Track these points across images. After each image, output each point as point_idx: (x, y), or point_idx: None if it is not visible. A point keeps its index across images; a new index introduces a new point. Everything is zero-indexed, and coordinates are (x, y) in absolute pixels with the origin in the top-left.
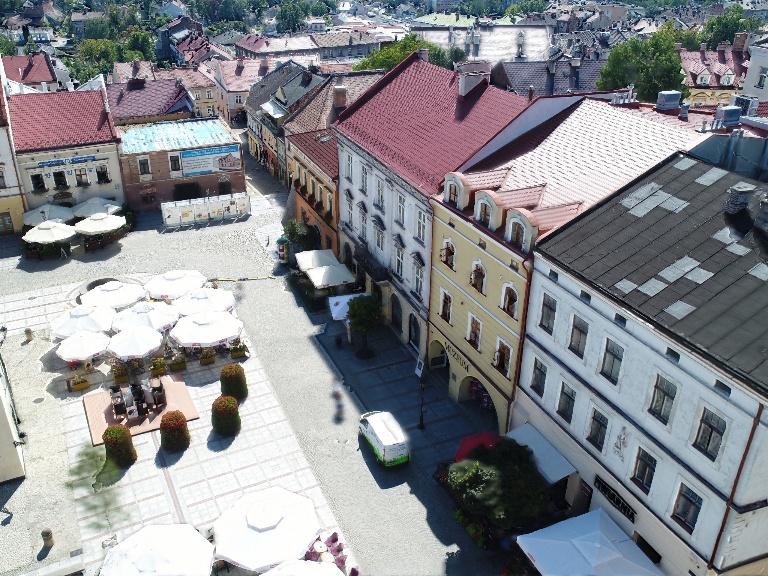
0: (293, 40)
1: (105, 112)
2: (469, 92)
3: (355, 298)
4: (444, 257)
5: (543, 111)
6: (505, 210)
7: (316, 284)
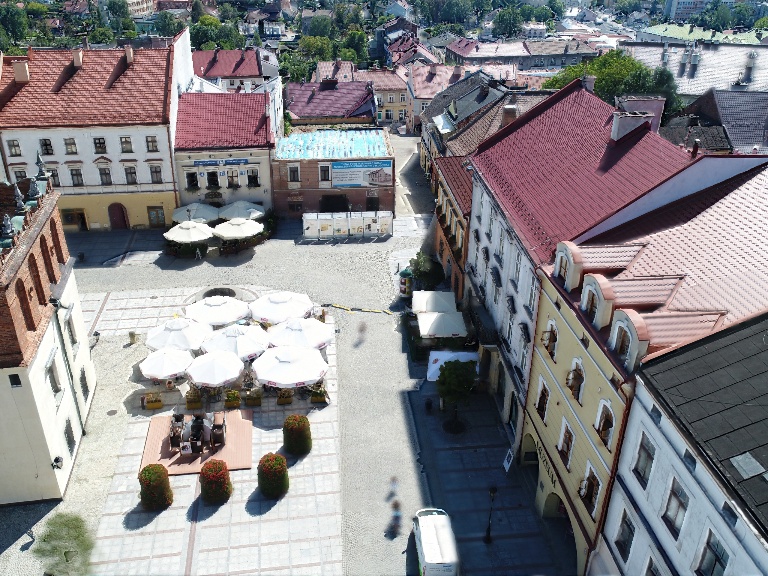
0: (504, 46)
1: (265, 116)
2: (623, 136)
3: (449, 362)
4: (547, 341)
5: (708, 174)
6: (616, 306)
7: (421, 332)
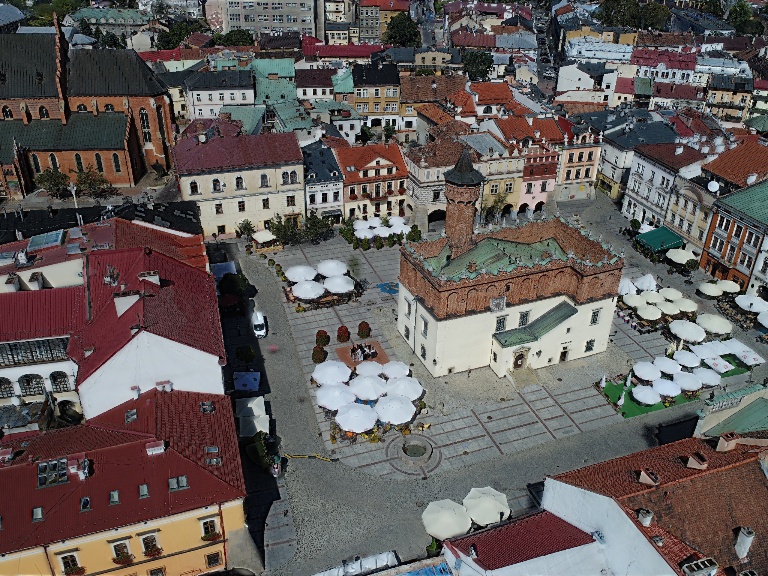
0: None
1: None
2: None
3: None
4: None
5: None
6: None
7: None
